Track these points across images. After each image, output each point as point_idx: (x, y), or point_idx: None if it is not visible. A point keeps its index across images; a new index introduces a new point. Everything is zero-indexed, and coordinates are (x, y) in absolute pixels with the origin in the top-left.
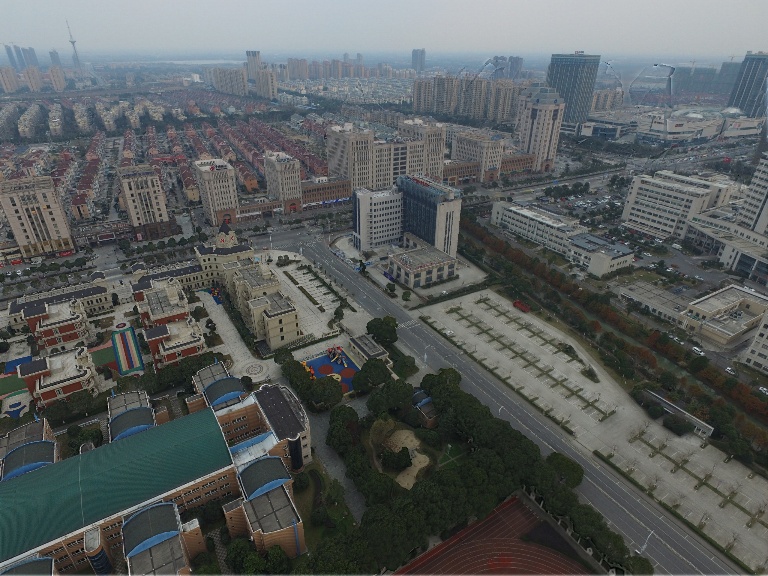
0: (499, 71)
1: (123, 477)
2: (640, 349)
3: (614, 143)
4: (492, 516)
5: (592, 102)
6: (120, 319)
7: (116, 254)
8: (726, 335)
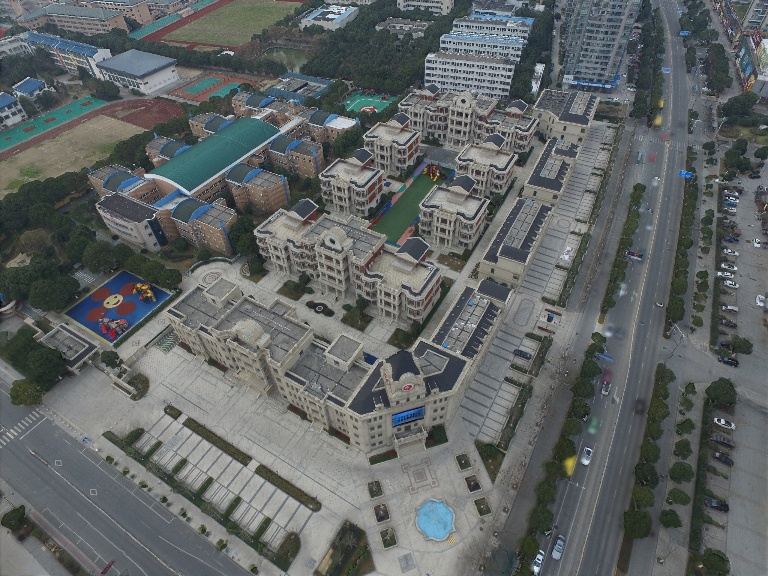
0: None
1: None
2: None
3: None
4: None
5: None
6: (444, 271)
7: None
8: None
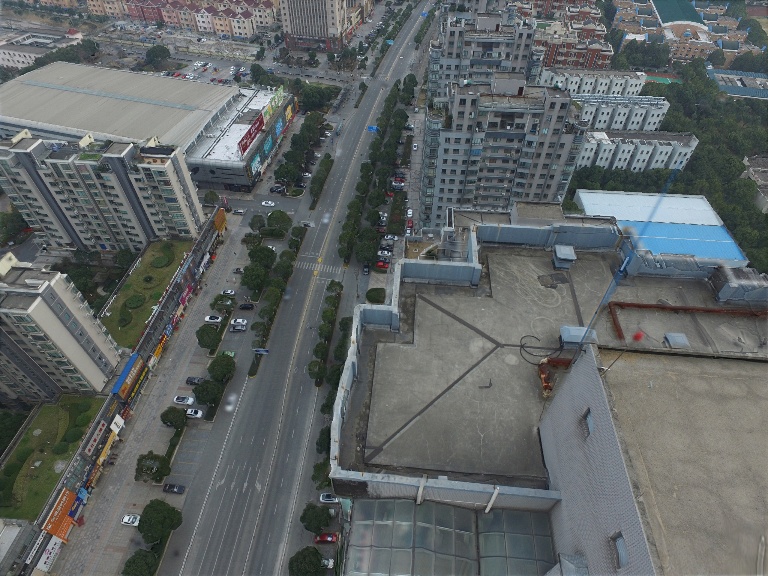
0: None
1: None
2: None
3: None
4: None
5: None
6: None
7: (396, 7)
8: None
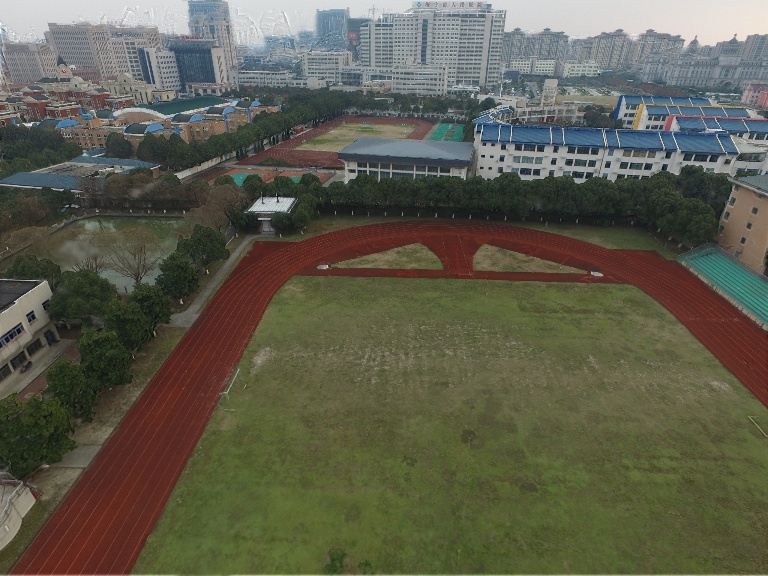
0: (146, 15)
1: (186, 102)
2: (355, 91)
3: (266, 64)
4: (341, 117)
5: (236, 37)
6: None
7: None
8: (382, 88)
